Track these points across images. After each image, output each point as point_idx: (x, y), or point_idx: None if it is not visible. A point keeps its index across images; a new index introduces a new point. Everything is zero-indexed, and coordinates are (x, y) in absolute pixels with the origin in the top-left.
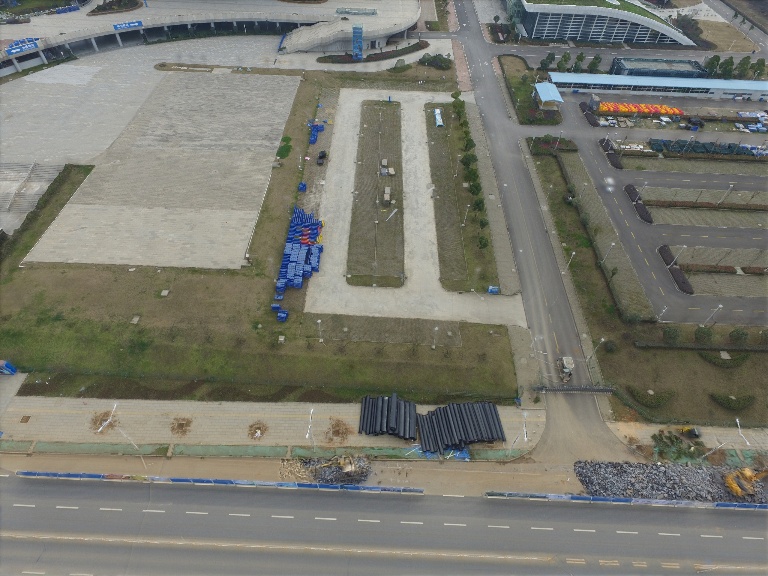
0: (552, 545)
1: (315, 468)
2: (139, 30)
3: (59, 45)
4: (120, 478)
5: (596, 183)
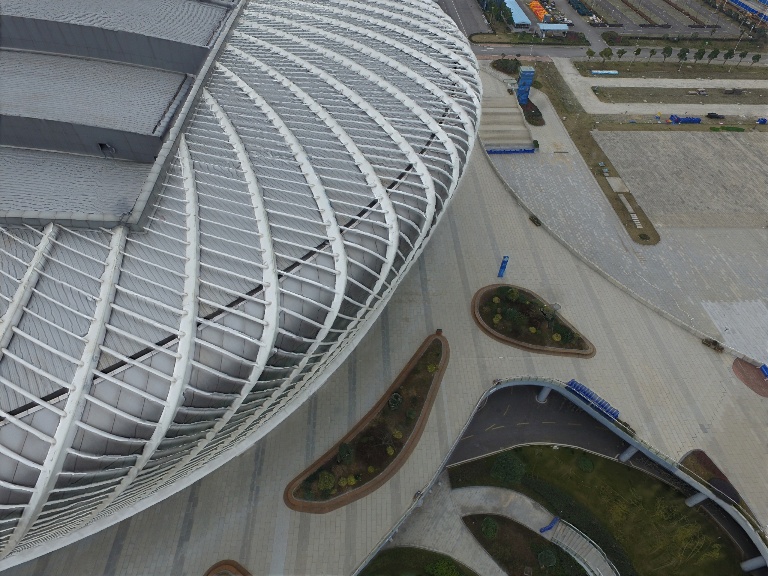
0: None
1: None
2: None
3: None
4: None
5: (646, 33)
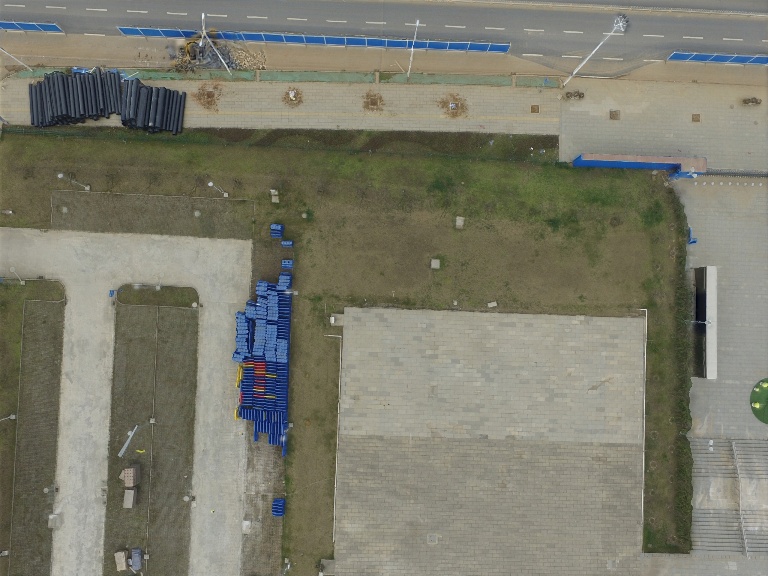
0: None
1: (230, 59)
2: None
3: None
4: (411, 39)
5: None
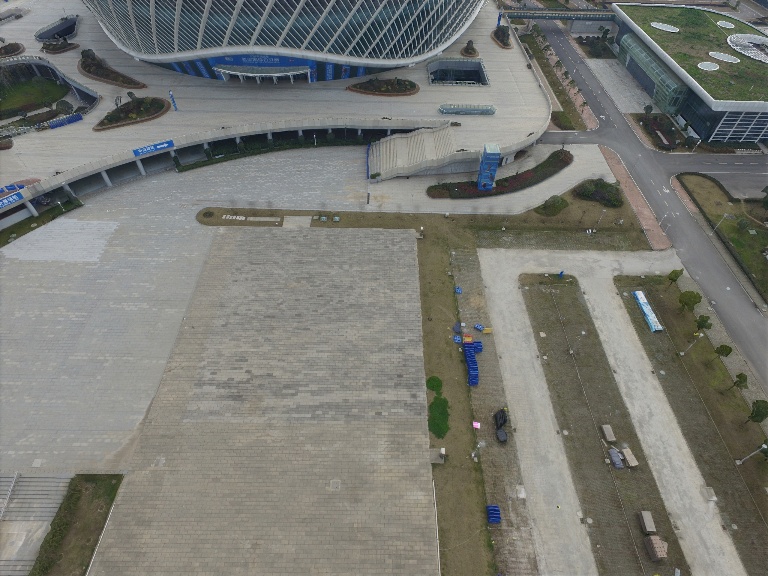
0: None
1: None
2: (169, 151)
3: (55, 188)
4: None
5: None
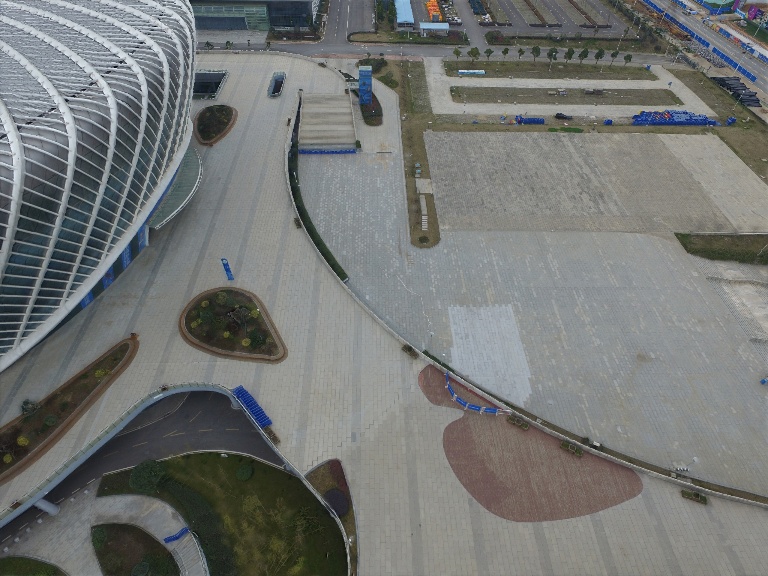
0: (755, 74)
1: None
2: None
3: None
4: None
5: (533, 32)
